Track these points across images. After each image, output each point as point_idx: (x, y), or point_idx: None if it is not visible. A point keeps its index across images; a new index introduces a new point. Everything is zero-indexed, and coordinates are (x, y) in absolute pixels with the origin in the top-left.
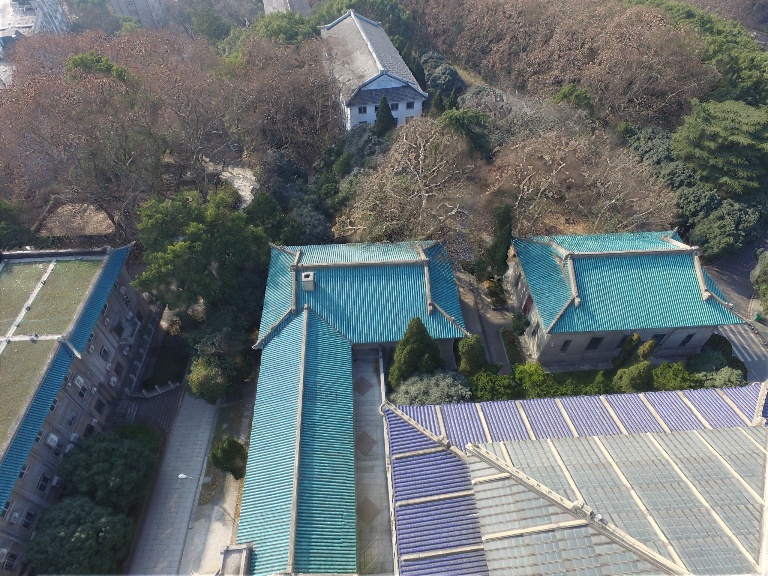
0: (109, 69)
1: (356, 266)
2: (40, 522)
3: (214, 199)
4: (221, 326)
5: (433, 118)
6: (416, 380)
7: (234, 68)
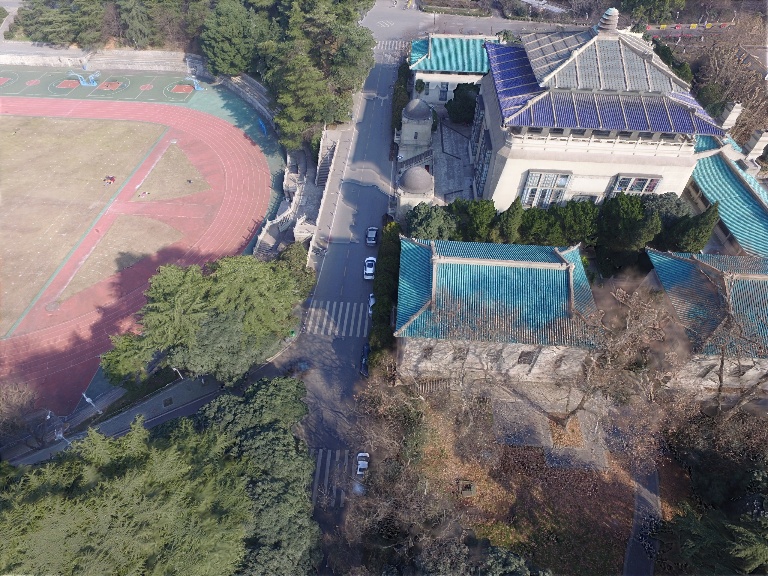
0: None
1: None
2: None
3: None
4: None
5: None
6: None
7: None
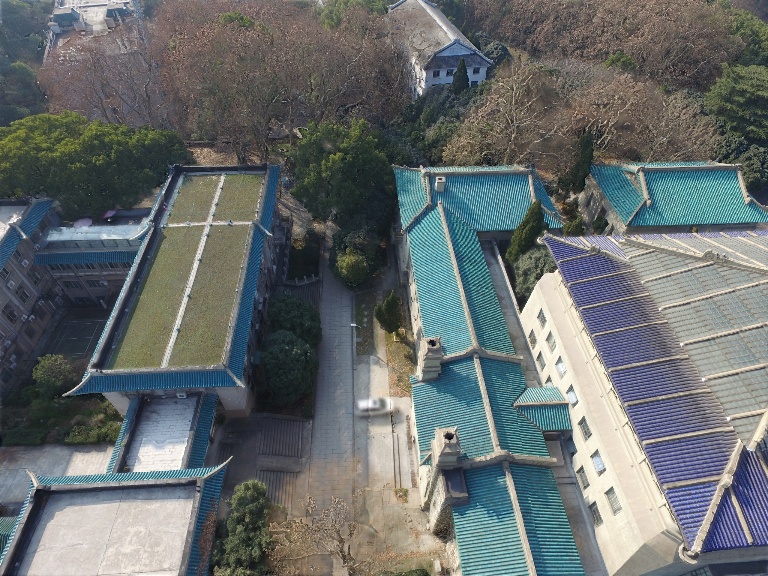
0: (251, 26)
1: (475, 174)
2: (266, 342)
3: (356, 124)
4: (356, 229)
5: None
6: (535, 250)
7: (322, 37)
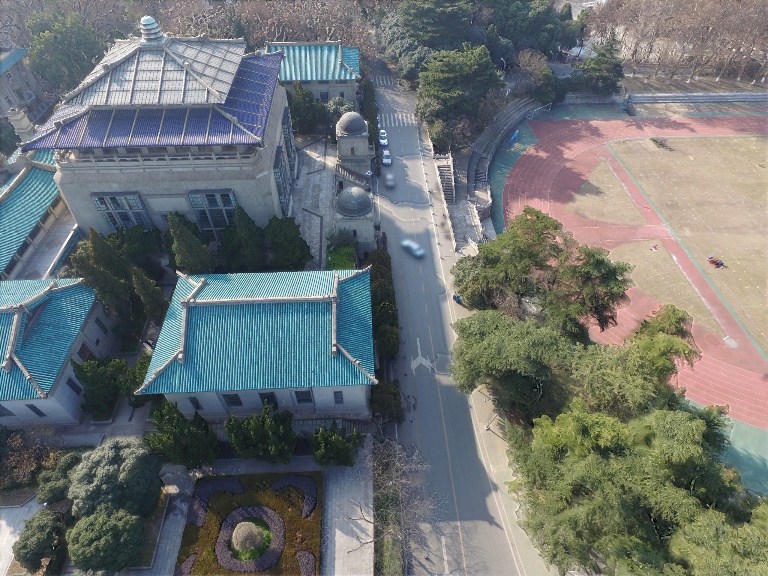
0: None
1: None
2: None
3: (72, 15)
4: None
5: None
6: None
7: None
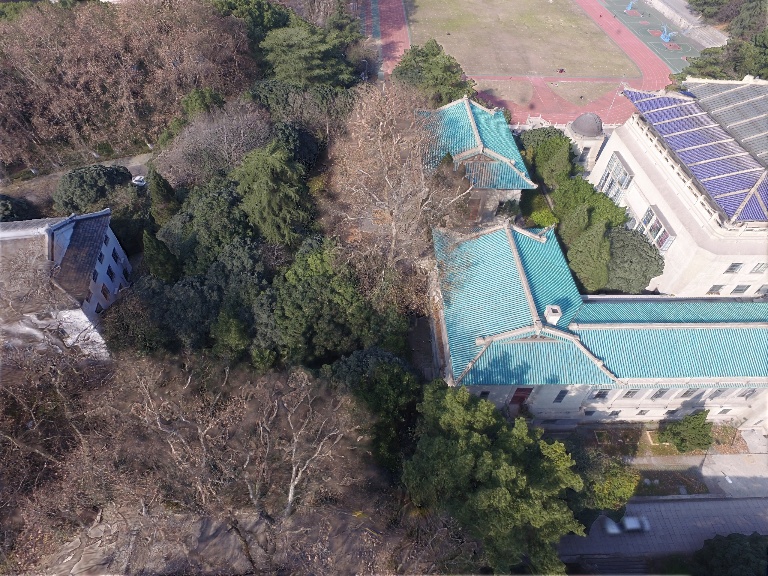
0: None
1: None
2: None
3: None
4: None
5: (174, 213)
6: (616, 256)
7: None
